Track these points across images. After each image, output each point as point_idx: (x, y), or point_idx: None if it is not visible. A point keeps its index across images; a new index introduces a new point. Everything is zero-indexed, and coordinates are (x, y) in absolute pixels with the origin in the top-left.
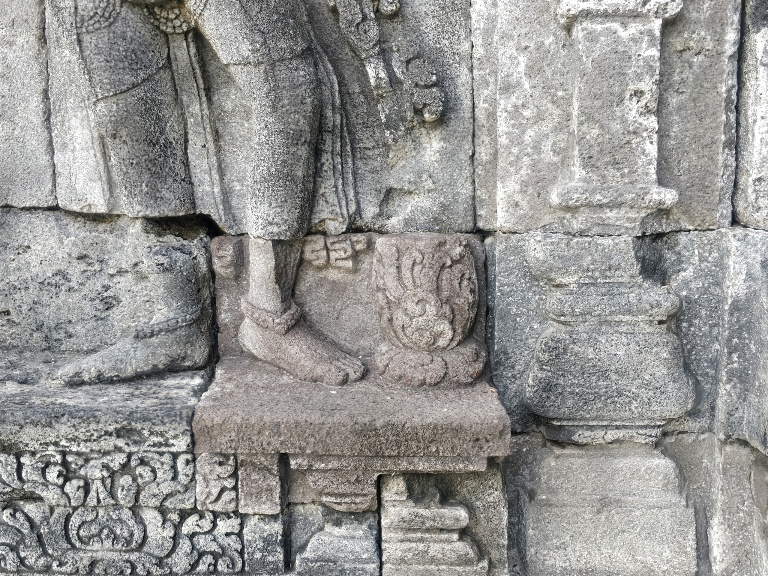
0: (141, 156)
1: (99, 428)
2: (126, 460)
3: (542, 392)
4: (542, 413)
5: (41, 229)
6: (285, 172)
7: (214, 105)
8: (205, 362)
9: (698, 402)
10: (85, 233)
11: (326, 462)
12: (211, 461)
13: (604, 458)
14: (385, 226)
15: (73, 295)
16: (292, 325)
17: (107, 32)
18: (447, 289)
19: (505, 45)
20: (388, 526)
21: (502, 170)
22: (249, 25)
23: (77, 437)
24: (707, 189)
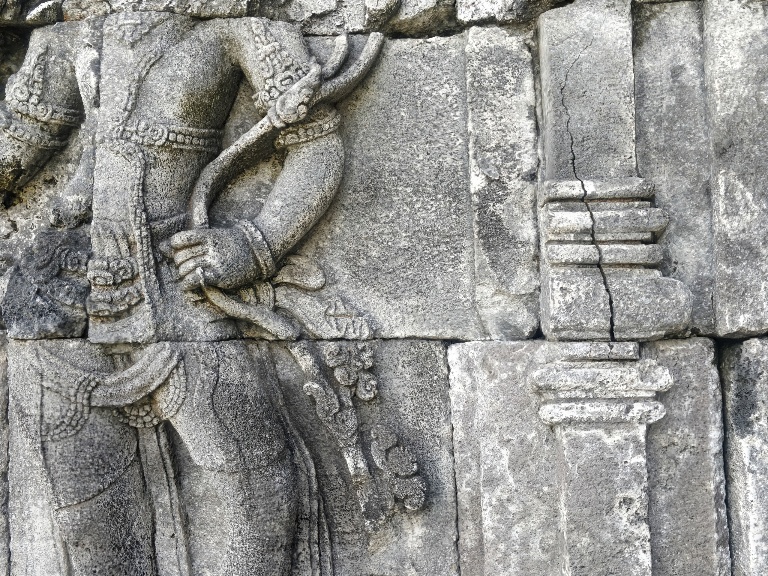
0: (105, 563)
1: None
2: None
3: None
4: None
5: None
6: None
7: (184, 489)
8: None
9: None
10: None
11: None
12: None
13: None
14: None
15: None
16: None
17: (73, 440)
18: None
19: (487, 437)
20: None
21: (489, 567)
22: (223, 434)
23: None
24: None
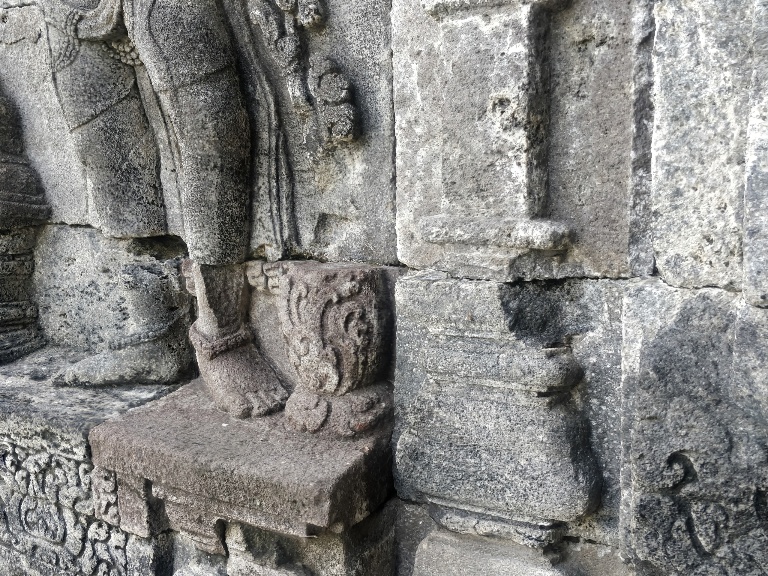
0: (106, 181)
1: (32, 428)
2: (48, 460)
3: (409, 459)
4: (412, 484)
5: (81, 244)
6: (199, 197)
7: None
8: (174, 378)
9: (598, 505)
10: (107, 249)
11: (178, 495)
12: (99, 474)
13: (479, 552)
14: (324, 254)
15: (101, 304)
16: (221, 351)
17: (70, 70)
18: (331, 328)
19: (401, 51)
20: (231, 575)
21: (398, 196)
22: (156, 54)
23: (20, 433)
24: (614, 224)
